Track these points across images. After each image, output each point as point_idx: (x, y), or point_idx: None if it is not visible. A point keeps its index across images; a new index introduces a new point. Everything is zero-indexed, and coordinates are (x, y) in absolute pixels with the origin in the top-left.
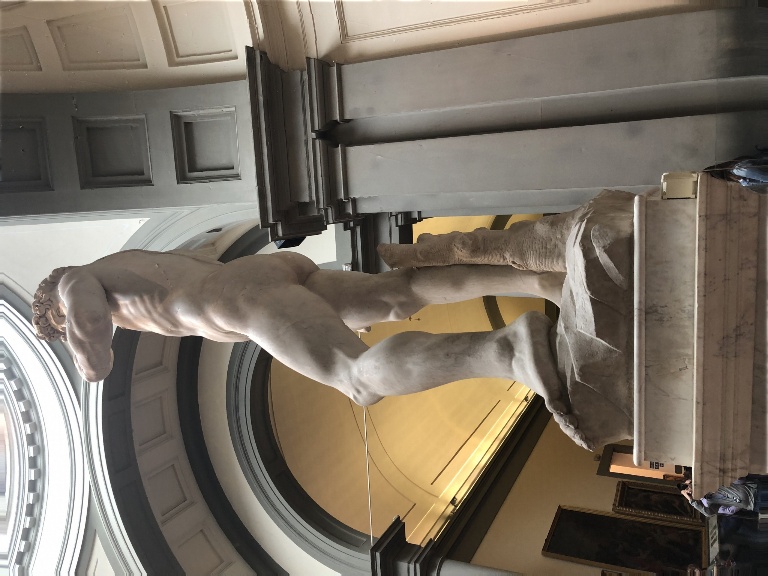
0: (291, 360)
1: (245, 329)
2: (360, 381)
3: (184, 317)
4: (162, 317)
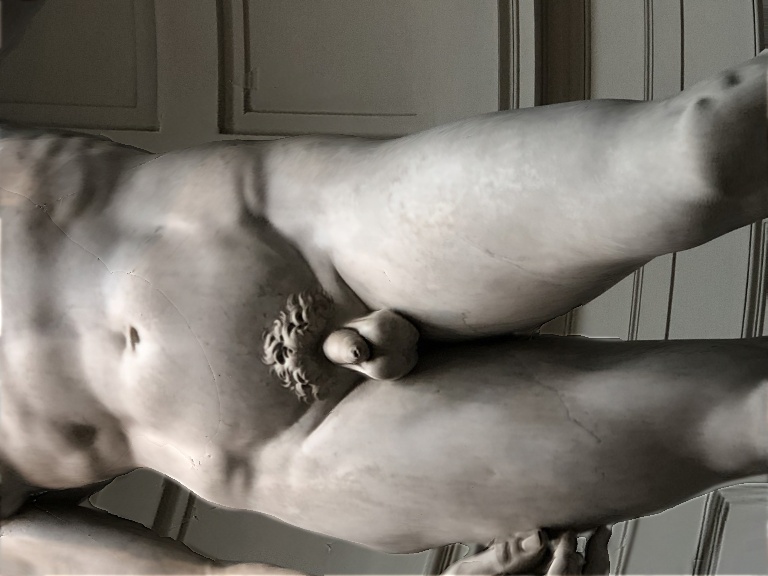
0: (512, 115)
1: (370, 147)
2: (764, 55)
3: (155, 168)
4: (82, 162)
